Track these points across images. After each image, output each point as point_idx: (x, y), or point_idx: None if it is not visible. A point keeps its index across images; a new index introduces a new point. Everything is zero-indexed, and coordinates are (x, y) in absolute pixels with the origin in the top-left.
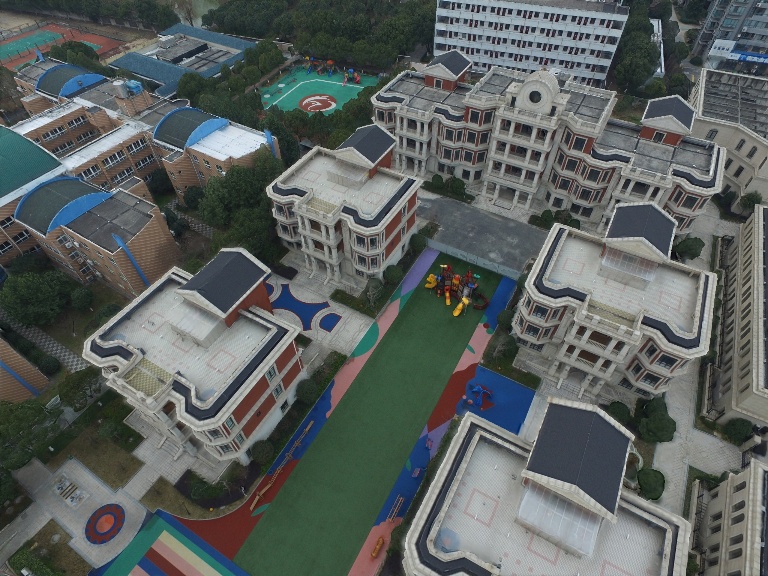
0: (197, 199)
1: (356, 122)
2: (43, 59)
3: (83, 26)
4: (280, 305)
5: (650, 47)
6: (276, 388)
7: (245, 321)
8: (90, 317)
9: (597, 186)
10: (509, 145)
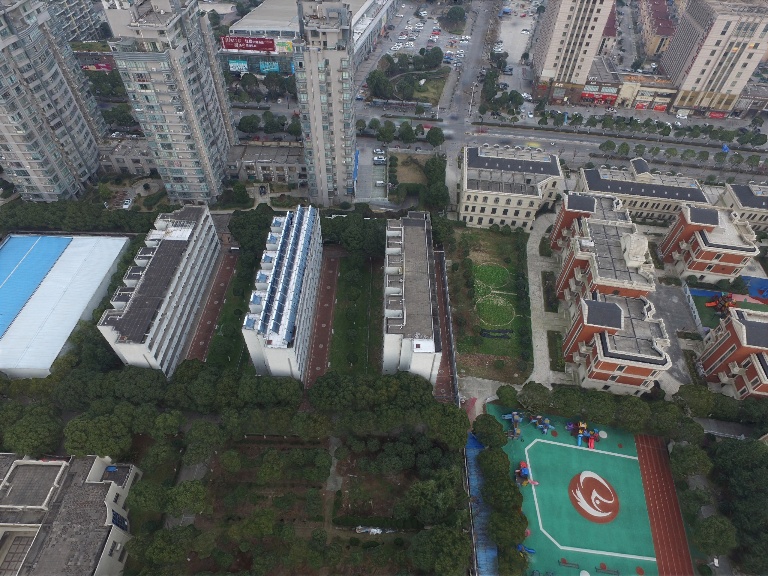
0: None
1: None
2: None
3: None
4: None
5: None
6: None
7: None
8: None
9: None
10: None
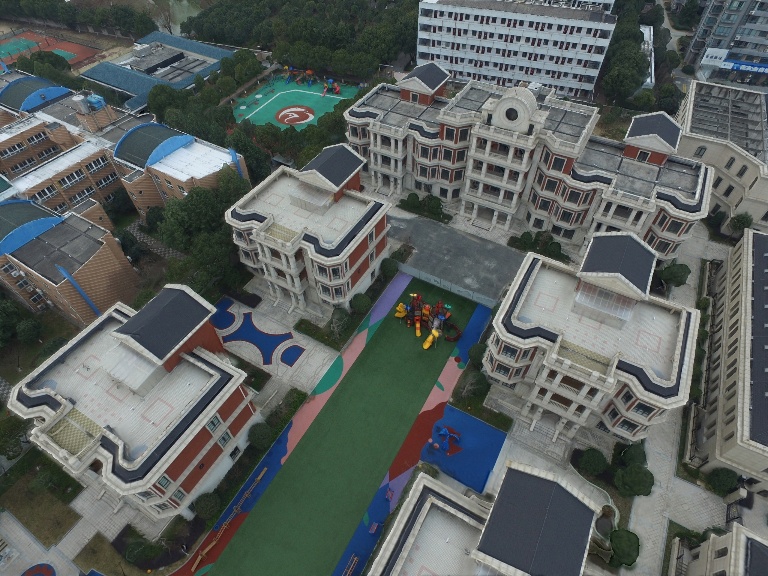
0: (159, 220)
1: (331, 137)
2: (8, 71)
3: (60, 34)
4: (240, 336)
5: (638, 57)
6: (222, 437)
7: (188, 365)
8: (38, 350)
9: (578, 208)
10: (486, 164)
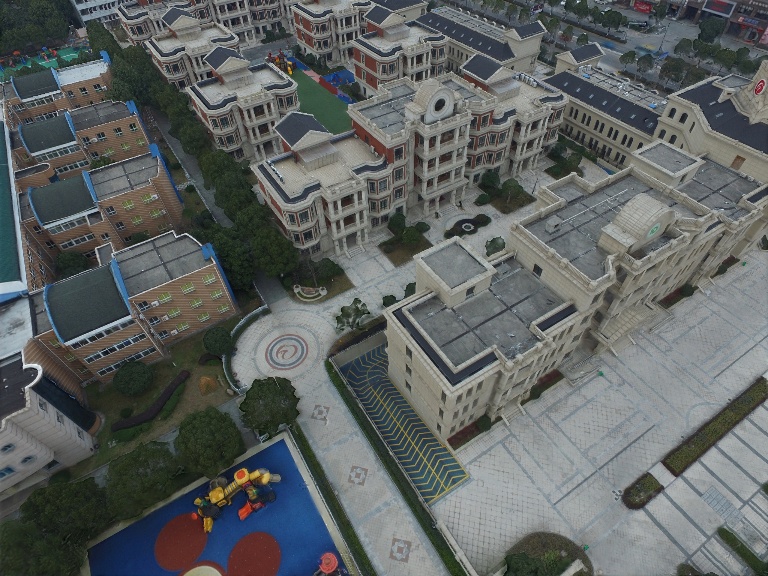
0: None
1: None
2: None
3: None
4: None
5: None
6: None
7: None
8: None
9: (277, 4)
10: (226, 5)
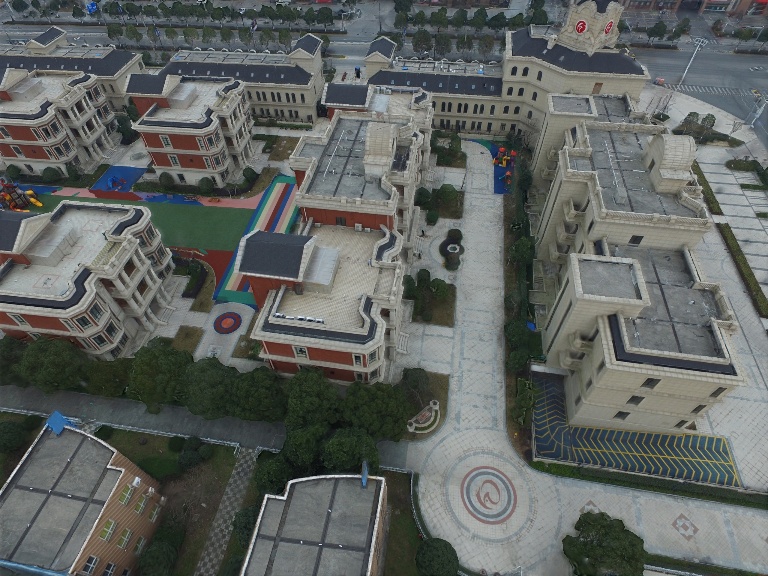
0: None
1: None
2: None
3: None
4: None
5: None
6: None
7: None
8: None
9: None
10: None
